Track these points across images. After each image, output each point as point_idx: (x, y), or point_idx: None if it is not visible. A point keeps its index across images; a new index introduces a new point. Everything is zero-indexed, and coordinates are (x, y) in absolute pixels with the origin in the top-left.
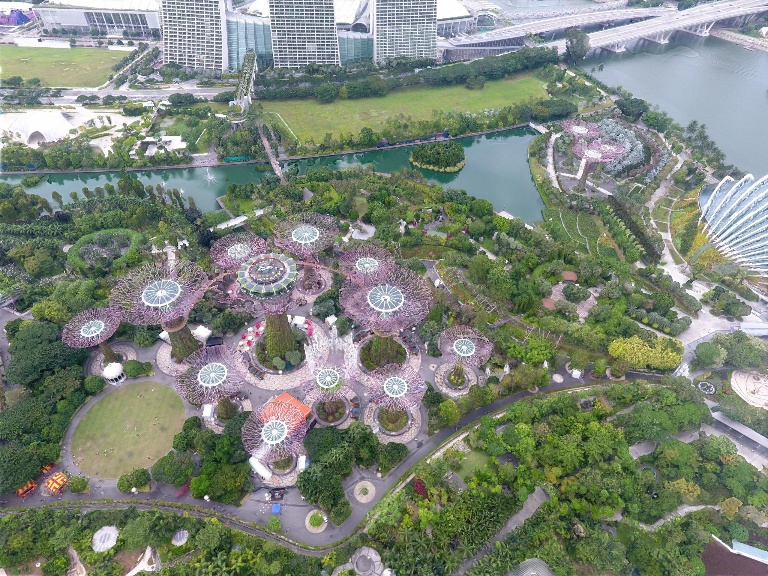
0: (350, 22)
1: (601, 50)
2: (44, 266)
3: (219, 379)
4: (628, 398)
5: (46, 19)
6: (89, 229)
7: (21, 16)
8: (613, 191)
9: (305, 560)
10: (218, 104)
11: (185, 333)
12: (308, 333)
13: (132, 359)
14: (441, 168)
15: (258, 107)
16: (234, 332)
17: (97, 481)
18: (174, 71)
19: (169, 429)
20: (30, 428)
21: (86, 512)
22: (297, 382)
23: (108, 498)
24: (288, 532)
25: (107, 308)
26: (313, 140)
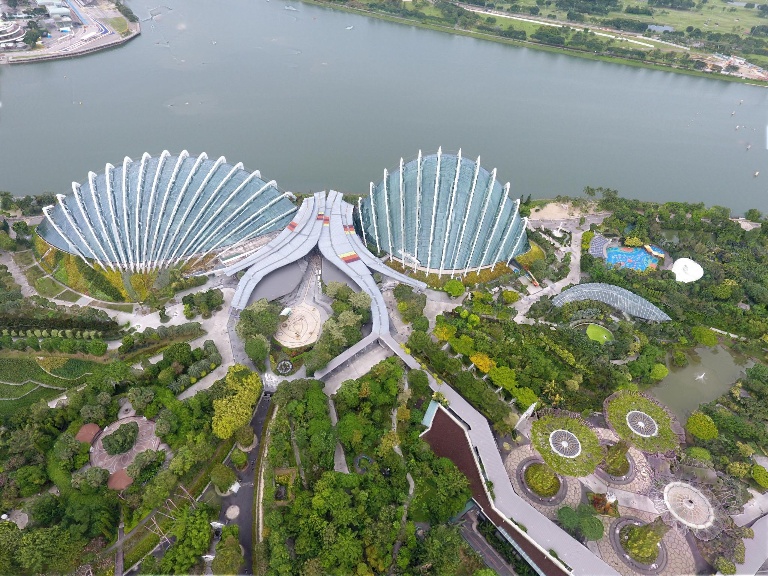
0: None
1: None
2: None
3: None
4: (289, 447)
5: None
6: None
7: None
8: None
9: None
10: None
11: None
12: None
13: None
14: None
15: None
16: None
17: None
18: None
19: None
20: None
21: None
22: None
23: None
24: None
25: None
26: None
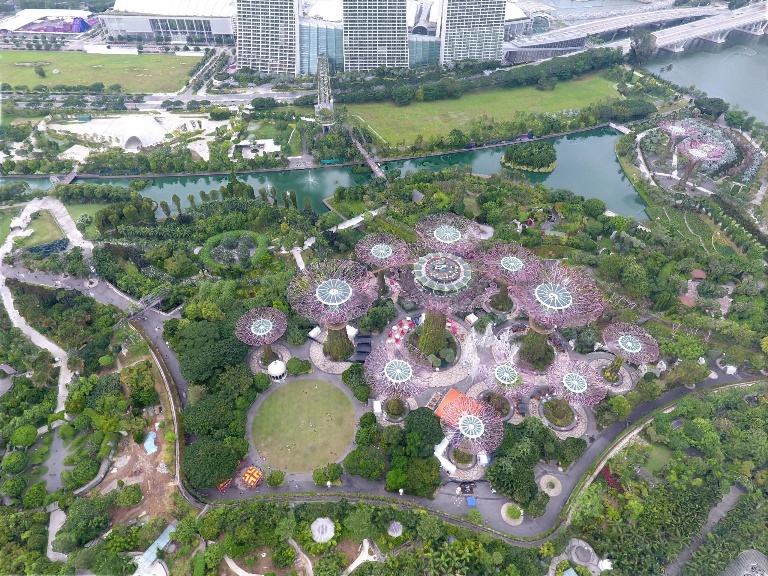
0: (411, 25)
1: (658, 50)
2: (185, 267)
3: (407, 375)
4: None
5: (111, 26)
6: (214, 231)
7: (83, 23)
8: (713, 190)
9: (522, 551)
10: (298, 108)
11: (344, 331)
12: (451, 331)
13: (288, 357)
14: (535, 169)
15: (343, 110)
16: (379, 330)
17: (288, 475)
18: (248, 76)
19: (343, 425)
20: (218, 424)
21: (293, 504)
22: (454, 379)
23: (303, 491)
24: (487, 524)
25: (270, 307)
26: (403, 142)
